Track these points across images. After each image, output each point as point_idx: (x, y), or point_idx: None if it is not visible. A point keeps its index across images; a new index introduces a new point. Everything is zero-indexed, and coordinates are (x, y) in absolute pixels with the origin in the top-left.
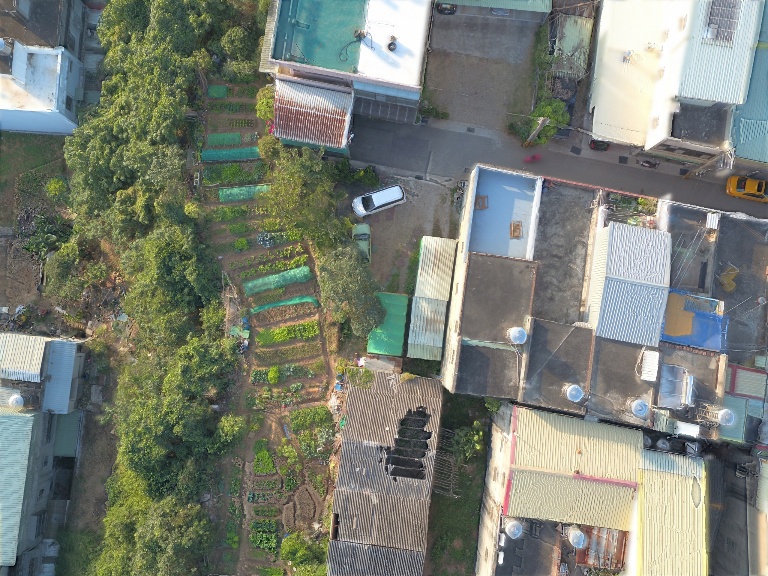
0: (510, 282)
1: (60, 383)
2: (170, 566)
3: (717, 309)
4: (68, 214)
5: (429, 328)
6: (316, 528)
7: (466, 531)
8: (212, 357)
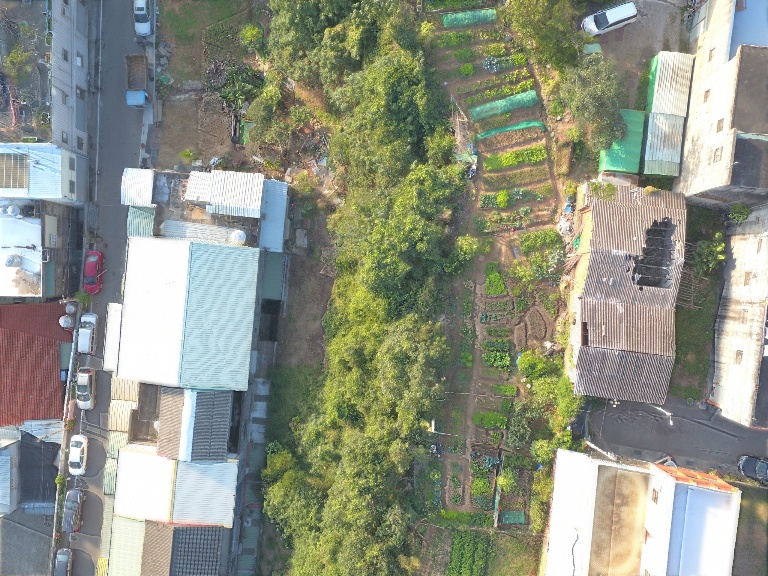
0: None
1: (274, 221)
2: (422, 375)
3: None
4: (257, 66)
5: (667, 144)
6: (549, 347)
7: (700, 346)
8: (442, 181)
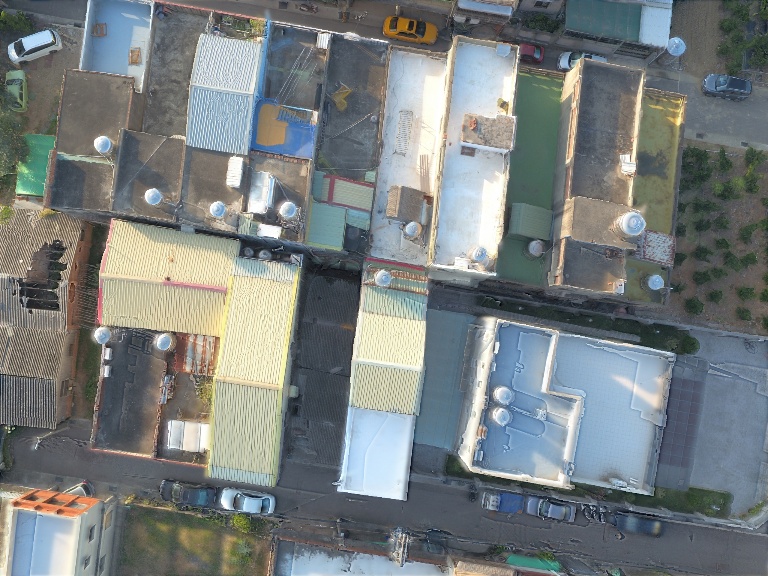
0: (107, 97)
1: None
2: None
3: (311, 119)
4: None
5: None
6: None
7: None
8: None
